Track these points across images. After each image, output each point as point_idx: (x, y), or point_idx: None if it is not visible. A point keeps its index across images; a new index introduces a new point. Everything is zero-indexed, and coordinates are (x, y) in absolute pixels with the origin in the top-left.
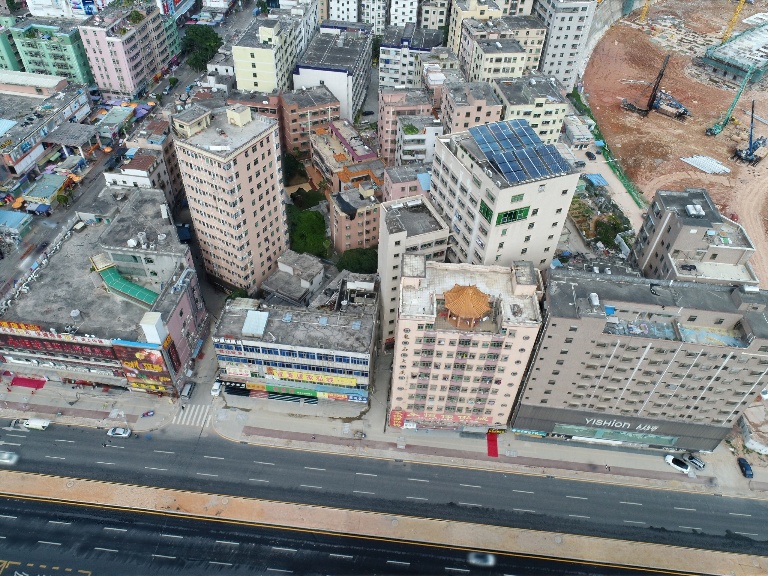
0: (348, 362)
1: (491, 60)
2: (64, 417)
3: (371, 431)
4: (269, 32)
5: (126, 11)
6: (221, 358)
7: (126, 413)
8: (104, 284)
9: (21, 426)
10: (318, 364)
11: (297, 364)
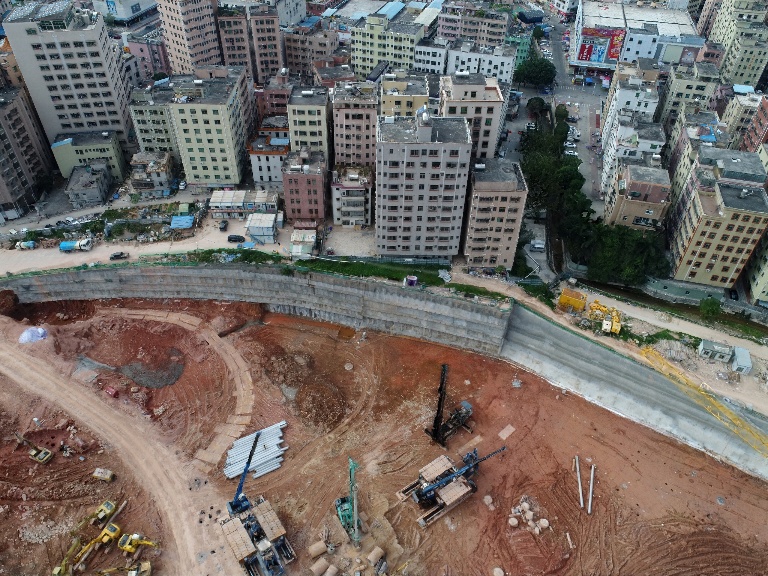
0: None
1: None
2: None
3: None
4: None
5: (480, 8)
6: None
7: None
8: None
9: None
10: None
11: None
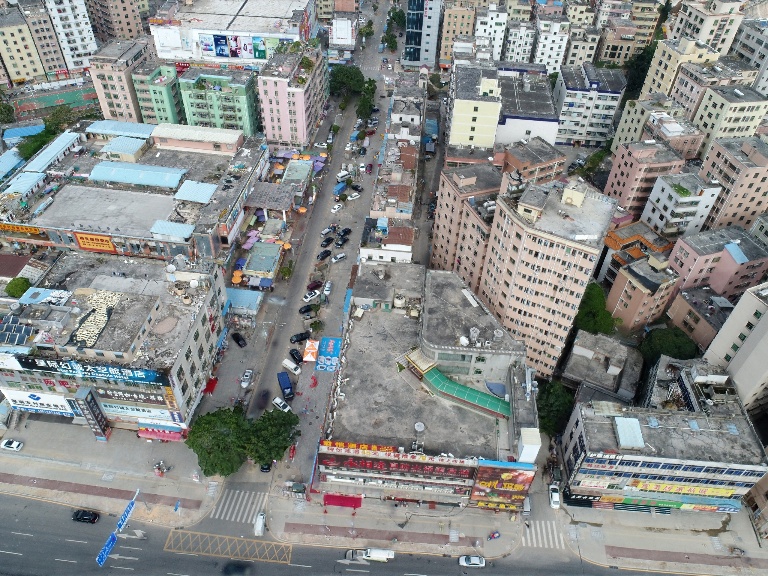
0: (739, 474)
1: (734, 109)
2: (401, 544)
3: (746, 546)
4: (492, 83)
5: (297, 58)
6: (583, 471)
7: (467, 535)
8: (423, 385)
9: (359, 558)
10: (700, 476)
11: (673, 476)
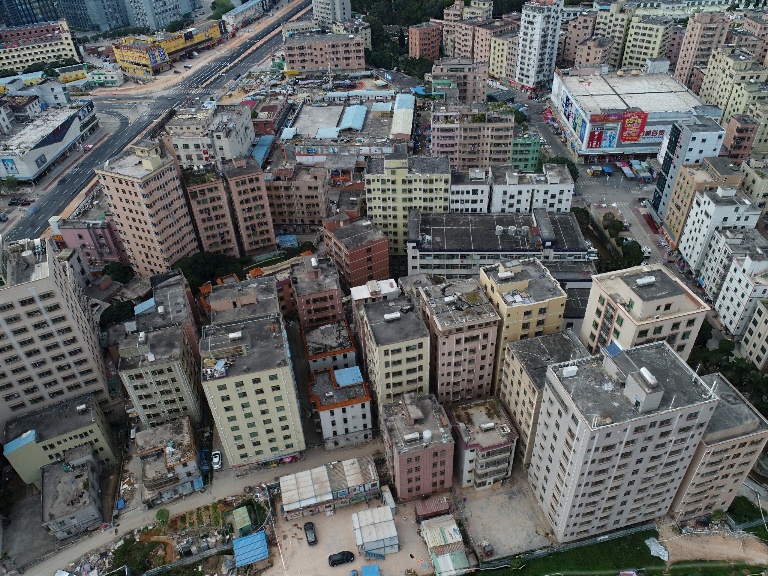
0: None
1: None
2: None
3: None
4: None
5: (478, 111)
6: None
7: None
8: None
9: None
10: None
11: None
